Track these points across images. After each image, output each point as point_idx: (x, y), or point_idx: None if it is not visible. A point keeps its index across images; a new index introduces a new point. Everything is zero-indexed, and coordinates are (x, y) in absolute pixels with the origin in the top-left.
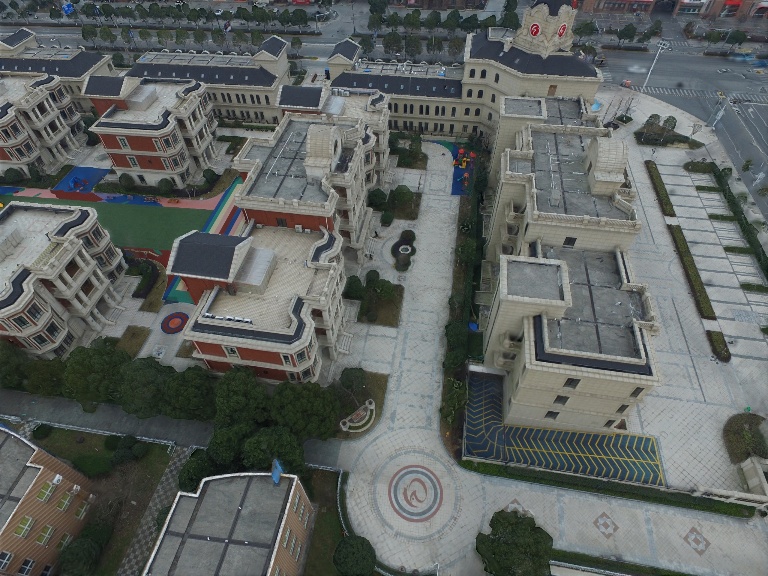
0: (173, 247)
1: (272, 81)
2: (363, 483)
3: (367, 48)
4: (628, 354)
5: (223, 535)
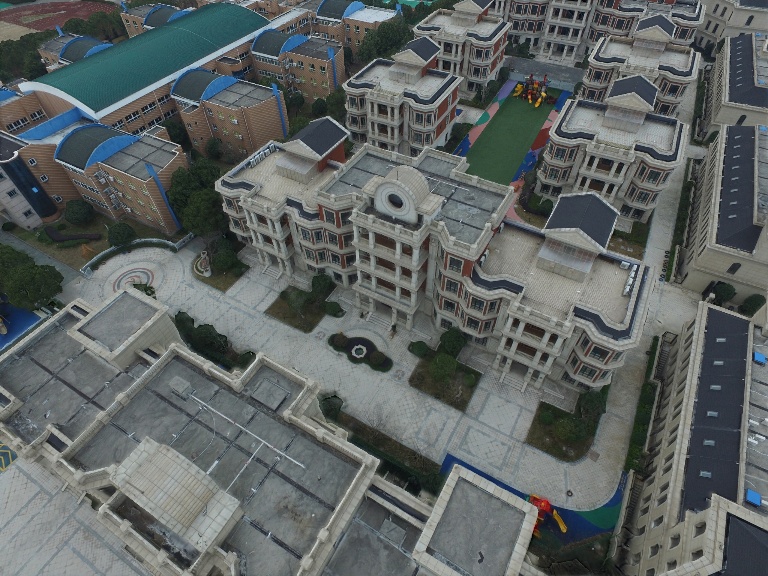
0: None
1: (735, 246)
2: (163, 258)
3: None
4: (7, 380)
5: (146, 158)
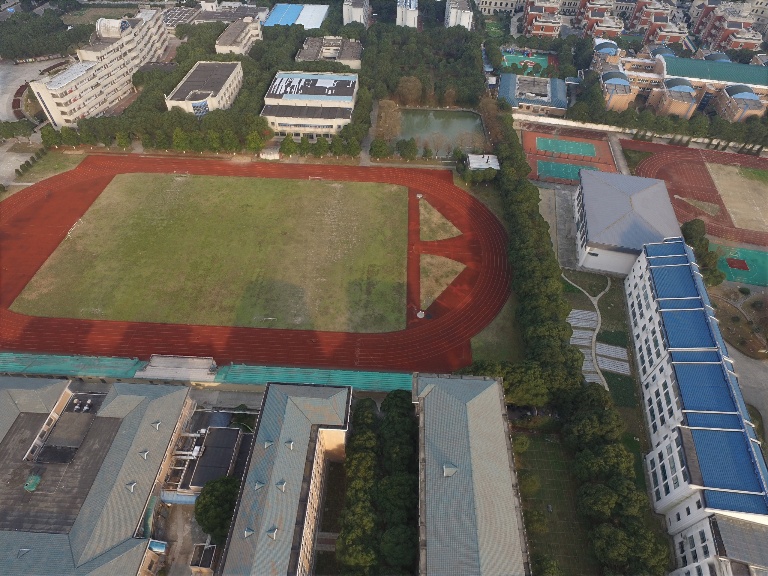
0: (726, 23)
1: (675, 5)
2: None
3: (684, 2)
4: None
5: None
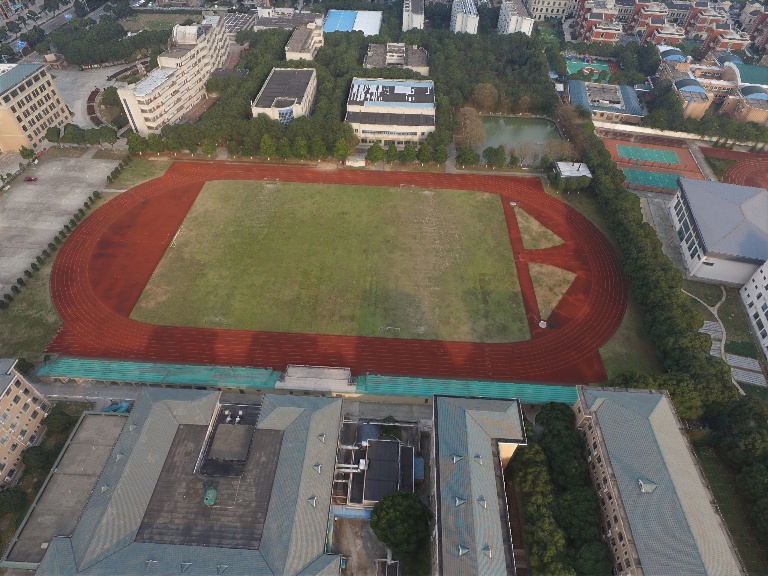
0: None
1: None
2: None
3: (732, 8)
4: None
5: None
